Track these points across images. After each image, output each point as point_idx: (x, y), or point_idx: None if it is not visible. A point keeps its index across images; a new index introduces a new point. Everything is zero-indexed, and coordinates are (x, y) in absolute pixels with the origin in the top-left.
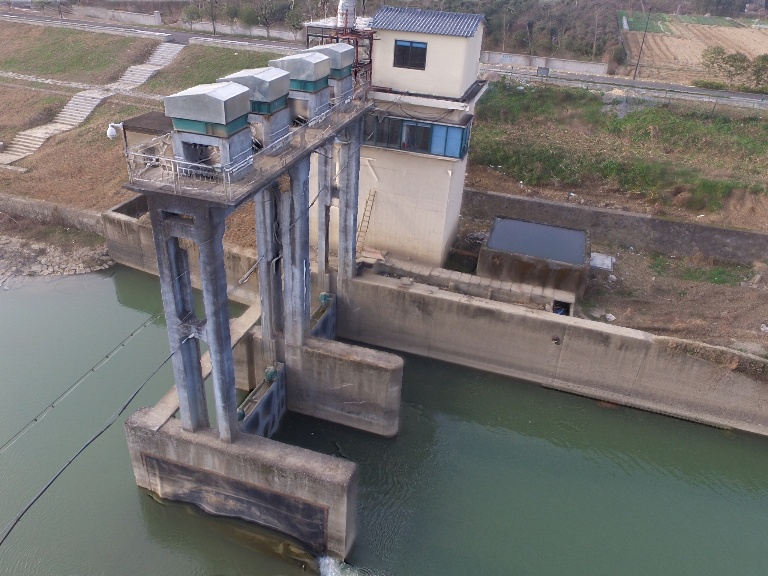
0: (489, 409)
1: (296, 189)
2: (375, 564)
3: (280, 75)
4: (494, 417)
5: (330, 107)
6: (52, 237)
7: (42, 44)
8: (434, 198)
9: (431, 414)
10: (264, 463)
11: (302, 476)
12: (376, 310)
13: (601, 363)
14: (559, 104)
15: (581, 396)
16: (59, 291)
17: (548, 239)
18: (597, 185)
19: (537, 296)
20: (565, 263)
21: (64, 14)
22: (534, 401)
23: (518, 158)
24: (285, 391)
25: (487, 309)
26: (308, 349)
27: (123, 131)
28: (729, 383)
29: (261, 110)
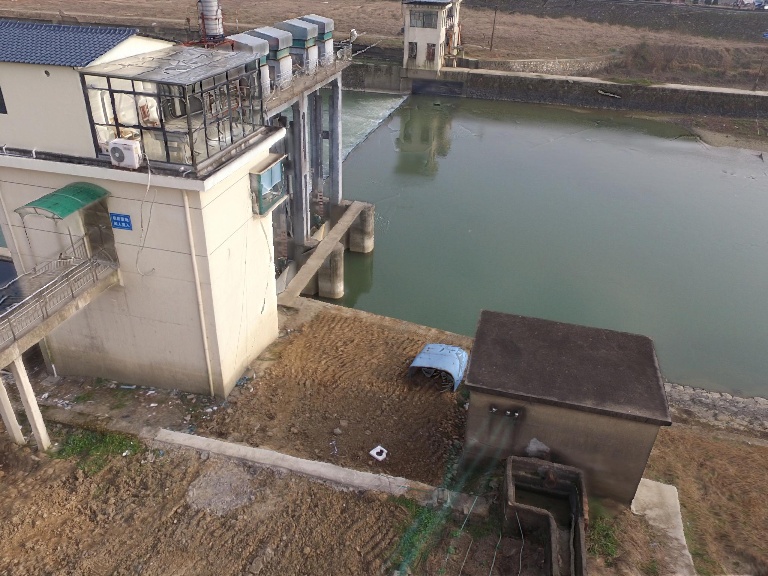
0: None
1: None
2: None
3: None
4: None
5: None
6: None
7: None
8: None
9: None
10: None
11: None
12: None
13: None
14: None
15: None
16: None
17: None
18: None
19: None
20: None
21: None
22: None
23: None
24: None
25: None
26: None
27: None
28: None
29: None
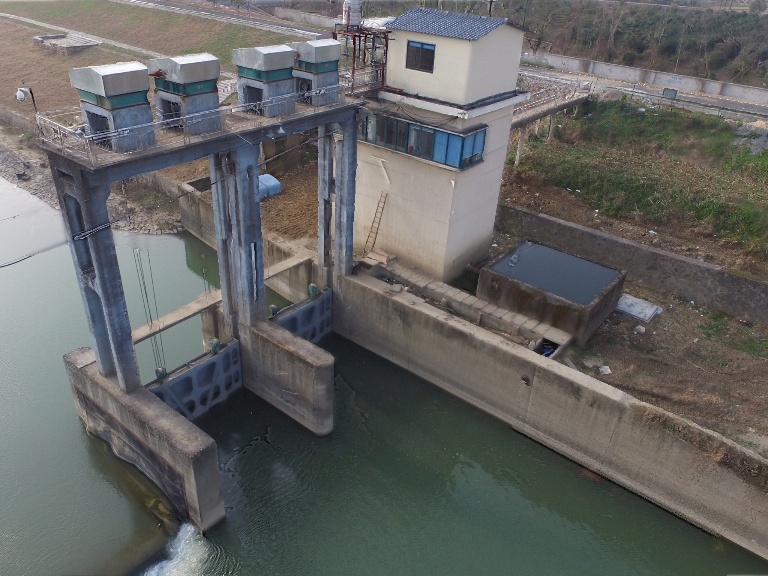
0: (439, 436)
1: (238, 172)
2: (232, 546)
3: (203, 60)
4: (440, 445)
5: (309, 100)
6: (145, 200)
7: (218, 38)
8: (438, 208)
9: (372, 424)
10: (140, 418)
11: (163, 438)
12: (364, 312)
13: (572, 417)
14: (682, 131)
15: (551, 450)
16: (130, 245)
17: (576, 273)
18: (685, 226)
19: (526, 329)
20: (564, 299)
21: (254, 14)
22: (498, 442)
23: (601, 184)
24: (241, 367)
25: (460, 331)
26: (255, 330)
27: (31, 95)
28: (715, 478)
29: (180, 91)
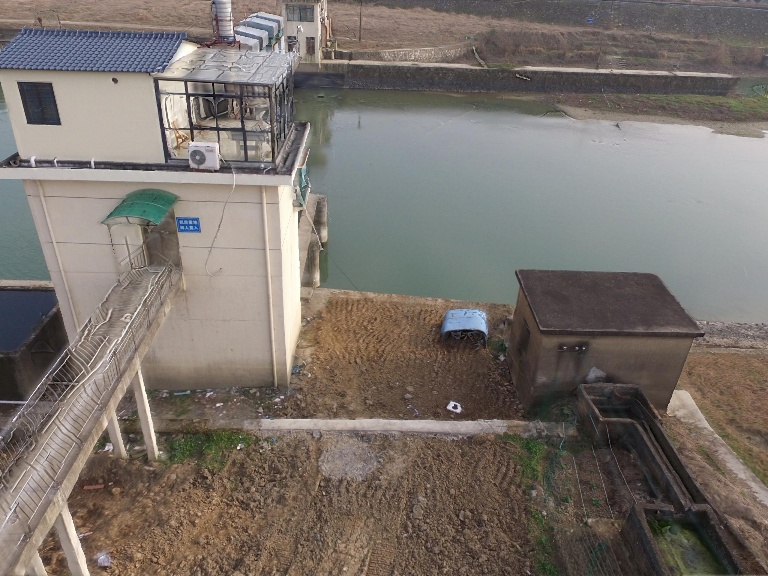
0: None
1: None
2: None
3: None
4: None
5: None
6: None
7: None
8: None
9: None
10: None
11: None
12: None
13: None
14: None
15: None
16: None
17: None
18: None
19: None
20: None
21: None
22: None
23: None
24: None
25: None
26: None
27: None
28: None
29: None
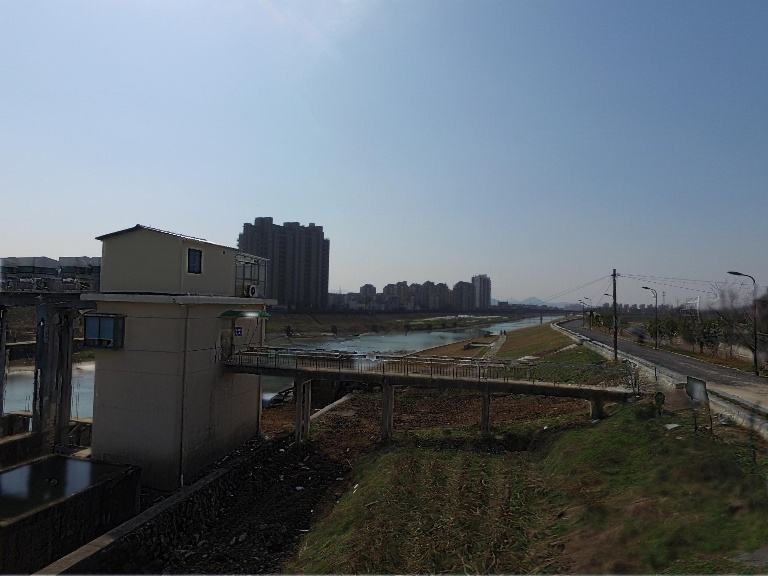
0: None
1: None
2: None
3: None
4: None
5: None
6: None
7: None
8: None
9: None
10: None
11: None
12: None
13: None
14: (673, 483)
15: None
16: None
17: None
18: None
19: None
20: None
21: None
22: None
23: None
24: None
25: None
26: None
27: None
28: None
29: None
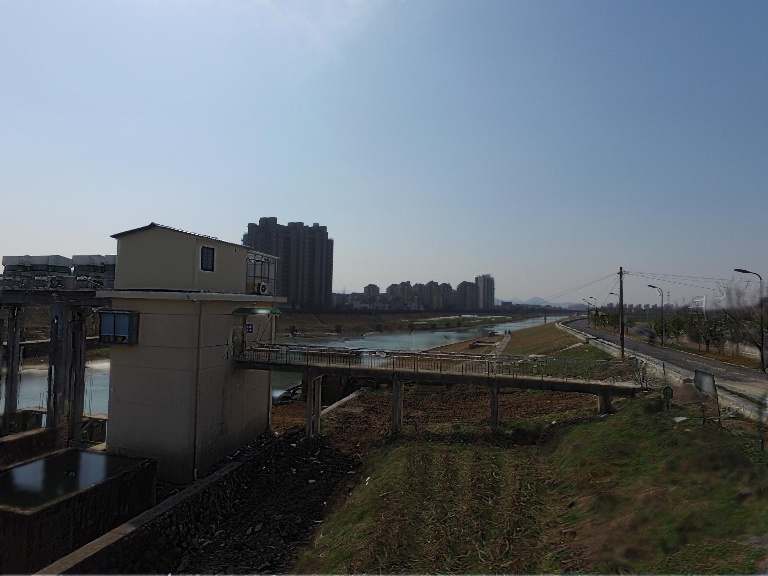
0: None
1: None
2: None
3: None
4: None
5: None
6: None
7: None
8: None
9: None
10: None
11: None
12: None
13: None
14: (682, 473)
15: None
16: None
17: None
18: None
19: None
20: None
21: None
22: None
23: None
24: None
25: None
26: None
27: None
28: None
29: None
